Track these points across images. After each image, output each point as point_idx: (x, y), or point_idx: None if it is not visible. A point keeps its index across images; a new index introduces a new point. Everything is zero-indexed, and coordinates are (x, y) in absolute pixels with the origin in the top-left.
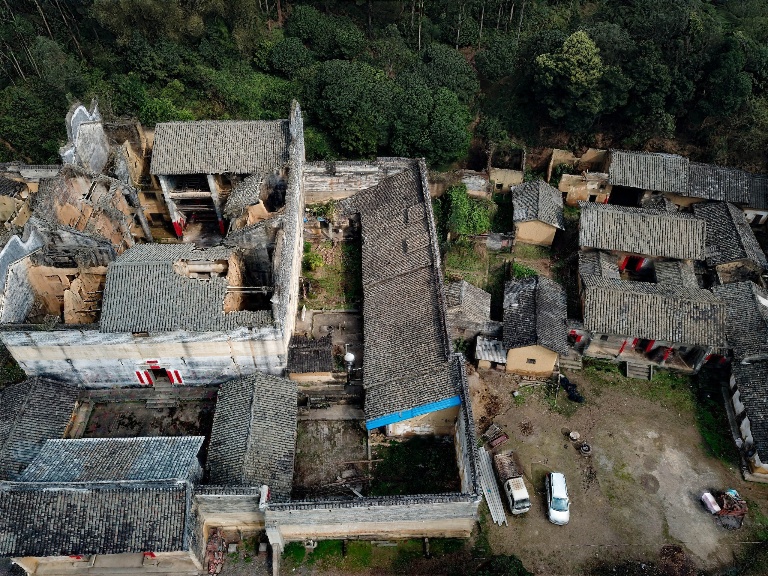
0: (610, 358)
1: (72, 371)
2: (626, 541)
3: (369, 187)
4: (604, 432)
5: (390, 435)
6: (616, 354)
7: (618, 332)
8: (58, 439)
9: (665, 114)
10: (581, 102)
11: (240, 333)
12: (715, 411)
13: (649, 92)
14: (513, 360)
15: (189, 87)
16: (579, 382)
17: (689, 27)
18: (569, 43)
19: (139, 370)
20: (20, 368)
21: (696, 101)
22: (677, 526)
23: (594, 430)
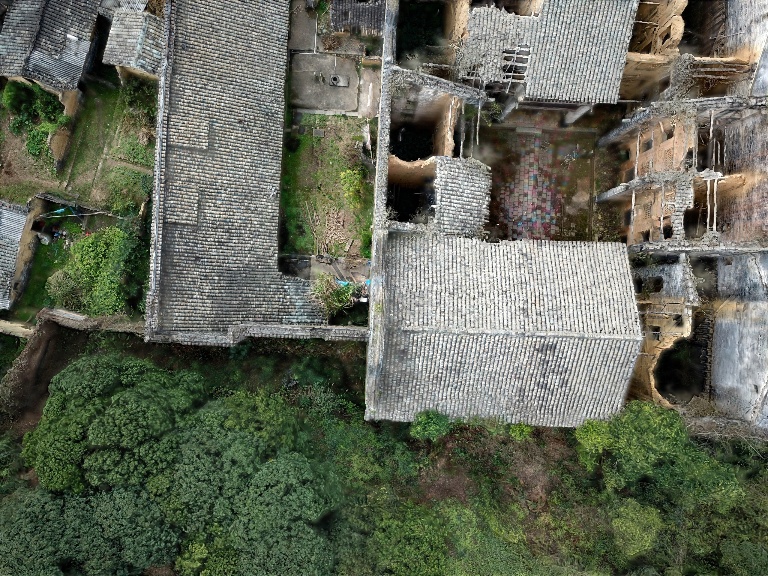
0: None
1: None
2: None
3: None
4: None
5: None
6: None
7: None
8: None
9: None
10: None
11: None
12: None
13: None
14: None
15: None
16: None
17: None
18: None
19: None
20: None
21: None
22: None
23: None
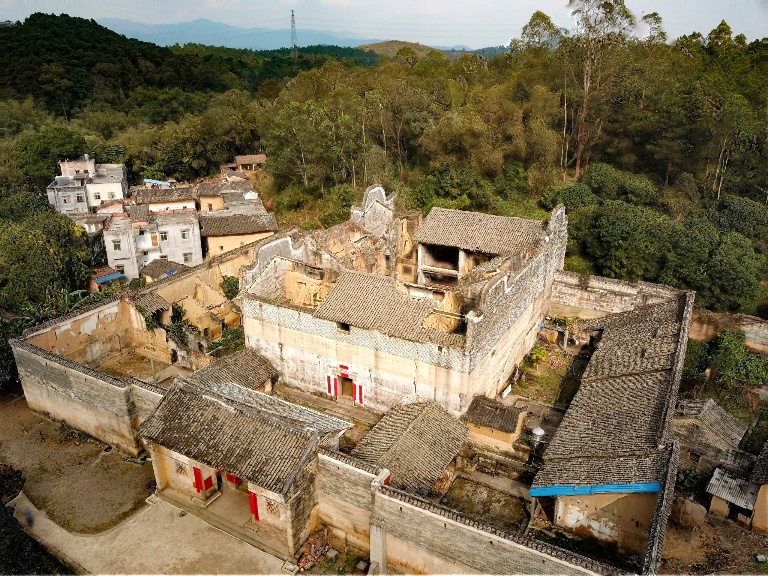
0: None
1: (279, 359)
2: None
3: (622, 311)
4: None
5: (558, 523)
6: None
7: None
8: (238, 385)
9: None
10: None
11: (429, 352)
12: None
13: None
14: (764, 510)
15: (475, 209)
16: None
17: None
18: None
19: (331, 375)
20: (245, 347)
21: None
22: None
23: None
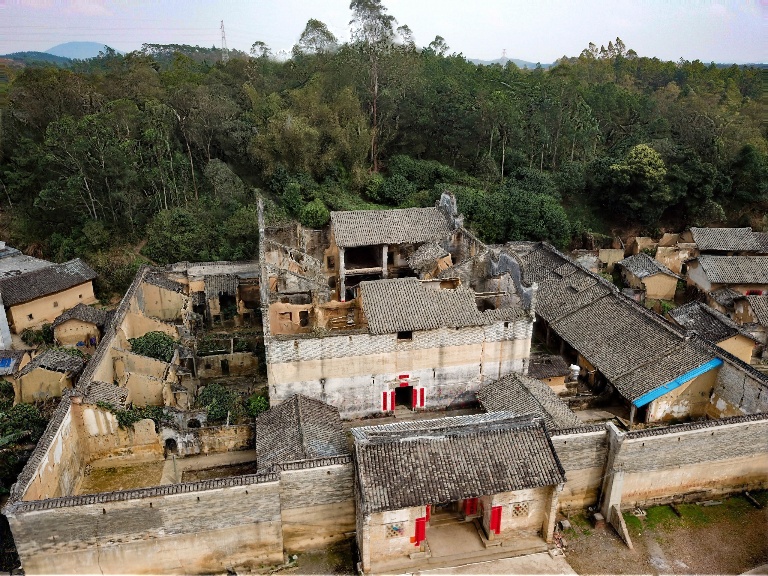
0: None
1: (320, 397)
2: None
3: None
4: None
5: (650, 421)
6: None
7: None
8: None
9: (715, 203)
10: (655, 194)
11: (496, 331)
12: None
13: (702, 184)
14: None
15: None
16: None
17: (713, 141)
18: (636, 152)
19: (387, 390)
20: (263, 400)
21: (734, 193)
22: None
23: None
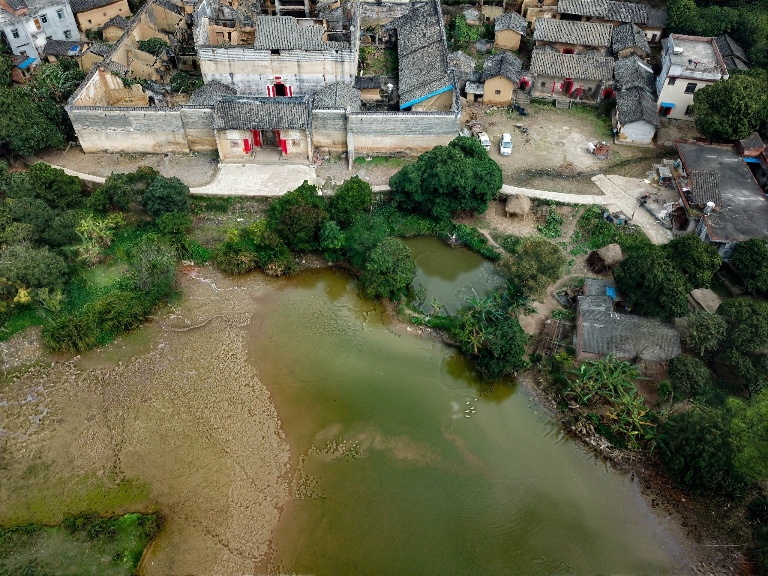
0: (547, 97)
1: (231, 84)
2: (542, 162)
3: (402, 15)
4: (538, 126)
5: None
6: (550, 95)
7: (549, 74)
8: None
9: None
10: None
11: (331, 55)
12: (605, 121)
13: None
14: (487, 92)
15: None
16: (527, 109)
17: None
18: None
19: (269, 85)
20: (201, 83)
21: None
22: (571, 157)
23: (532, 125)
